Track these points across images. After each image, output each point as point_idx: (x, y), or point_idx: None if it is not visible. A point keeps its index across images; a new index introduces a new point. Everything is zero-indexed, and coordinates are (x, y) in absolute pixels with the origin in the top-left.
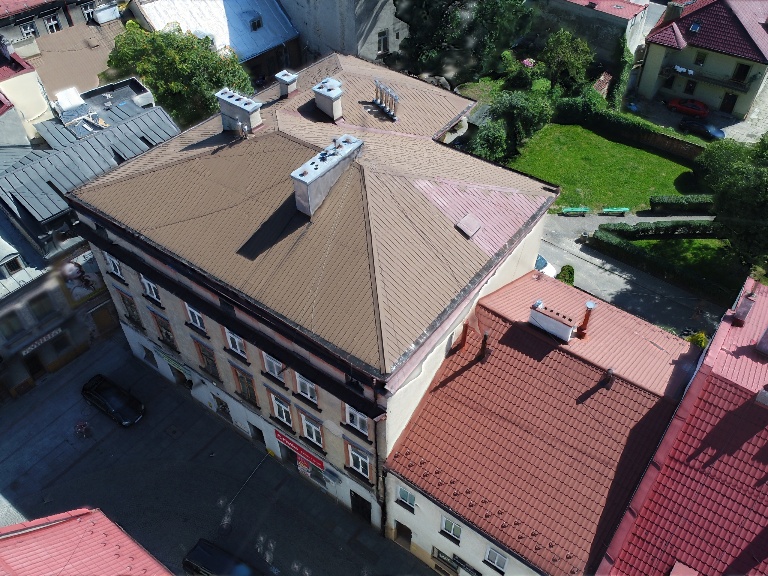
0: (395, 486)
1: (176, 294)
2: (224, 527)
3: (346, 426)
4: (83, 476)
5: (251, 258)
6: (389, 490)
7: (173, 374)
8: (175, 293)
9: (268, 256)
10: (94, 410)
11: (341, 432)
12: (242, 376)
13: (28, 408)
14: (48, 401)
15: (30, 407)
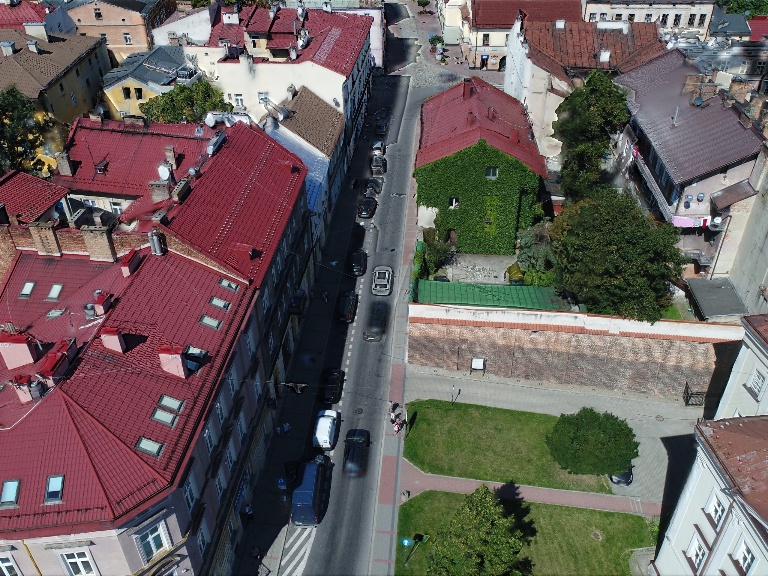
0: None
1: None
2: None
3: None
4: None
5: None
6: None
7: None
8: None
9: None
10: None
11: None
12: None
13: None
14: None
15: None
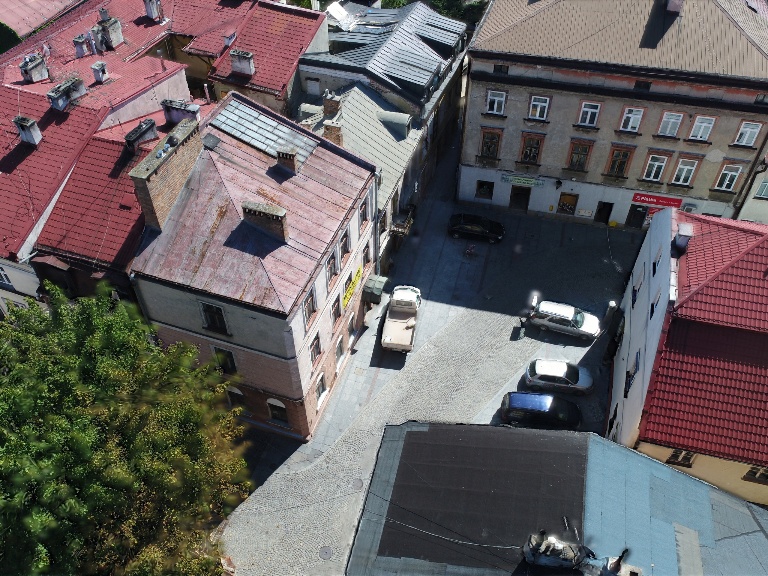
0: (760, 183)
1: (592, 93)
2: (621, 272)
3: (734, 146)
4: (498, 277)
5: (653, 47)
6: (752, 190)
7: (510, 198)
8: (591, 92)
9: (665, 43)
10: (463, 241)
11: (723, 156)
12: (616, 156)
13: (412, 254)
14: (422, 246)
15: (413, 253)
